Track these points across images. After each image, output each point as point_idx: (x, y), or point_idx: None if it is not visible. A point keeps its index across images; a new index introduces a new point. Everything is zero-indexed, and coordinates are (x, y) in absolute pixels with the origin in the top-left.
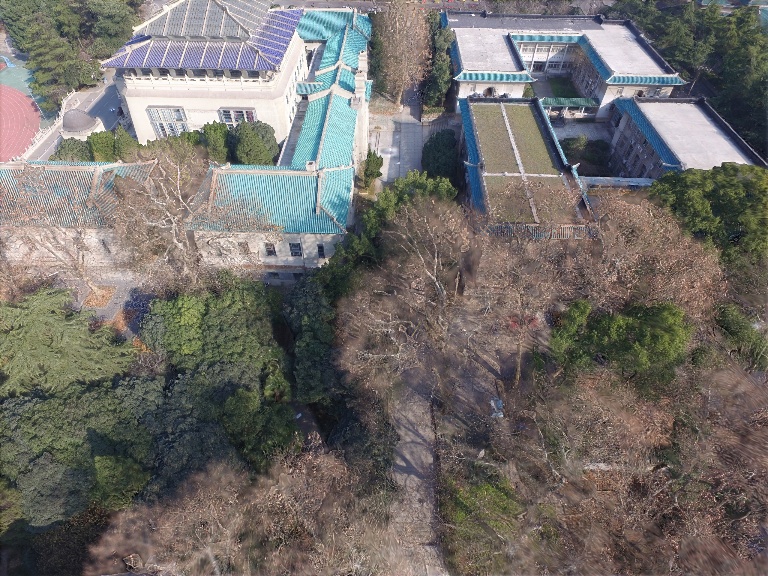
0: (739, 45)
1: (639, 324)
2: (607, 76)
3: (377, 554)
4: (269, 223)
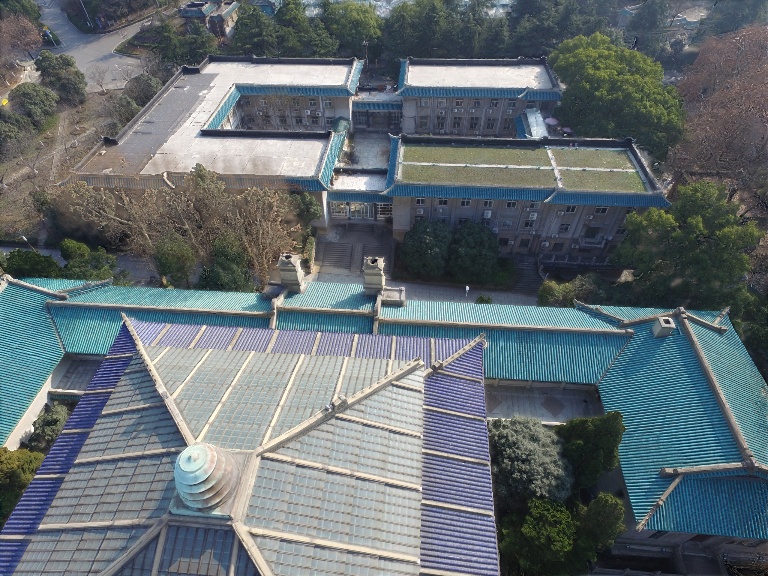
0: (309, 23)
1: None
2: (343, 92)
3: None
4: (764, 394)
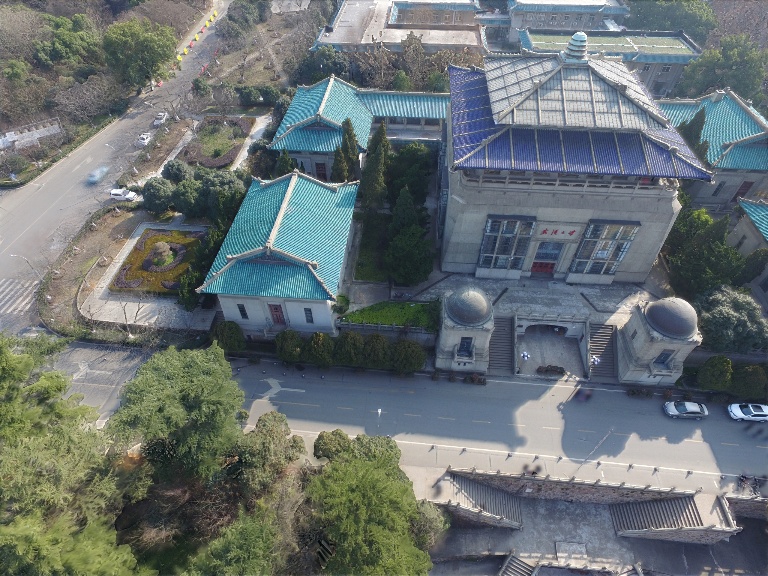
0: None
1: None
2: (472, 7)
3: None
4: None
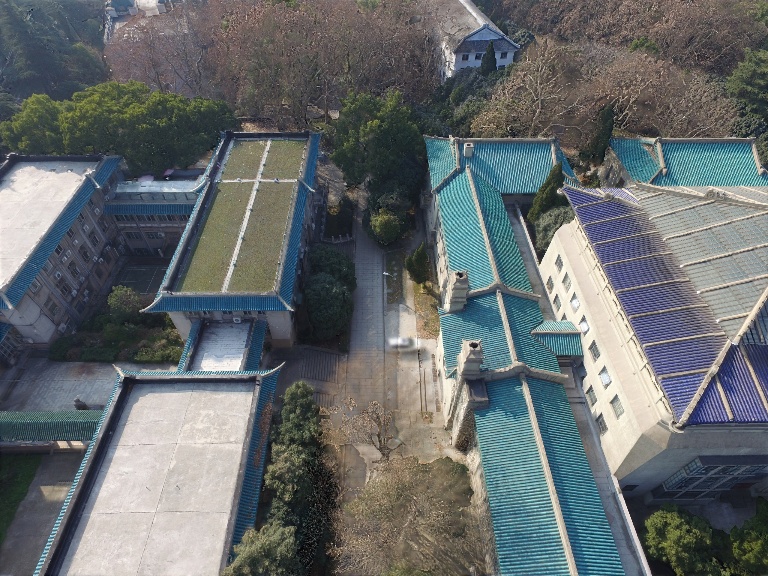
0: None
1: (287, 1)
2: None
3: (387, 0)
4: None
